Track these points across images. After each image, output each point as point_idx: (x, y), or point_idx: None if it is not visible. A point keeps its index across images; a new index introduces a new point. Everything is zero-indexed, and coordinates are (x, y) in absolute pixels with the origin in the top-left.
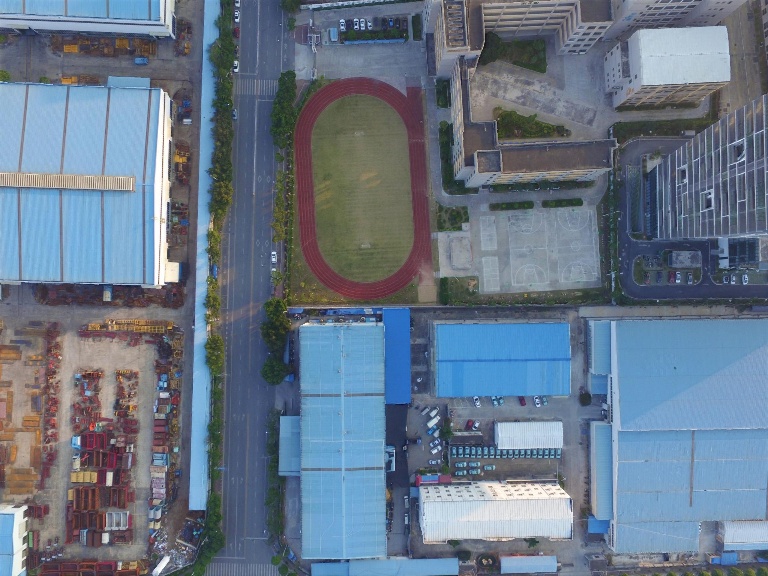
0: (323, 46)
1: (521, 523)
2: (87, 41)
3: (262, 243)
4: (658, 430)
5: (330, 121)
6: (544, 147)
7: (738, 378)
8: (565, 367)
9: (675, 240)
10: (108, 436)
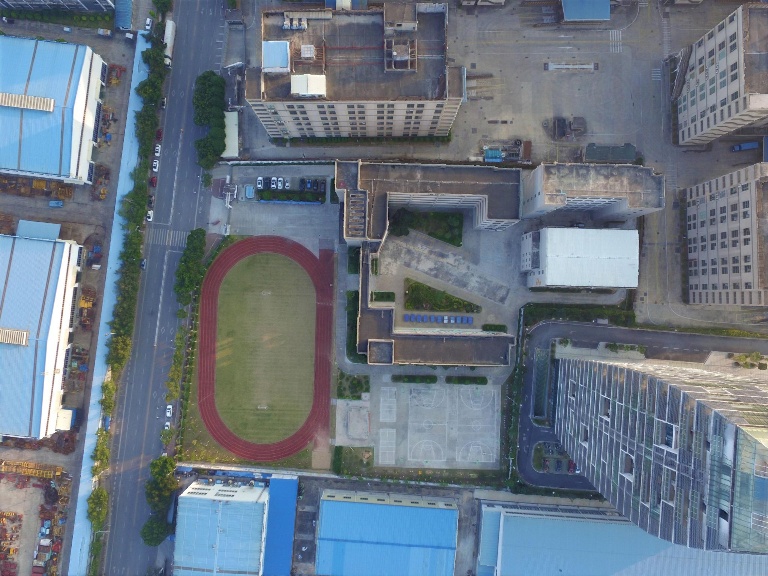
0: (239, 201)
1: None
2: (4, 180)
3: (159, 395)
4: None
5: (239, 277)
6: (441, 338)
7: None
8: (449, 556)
9: None
10: None
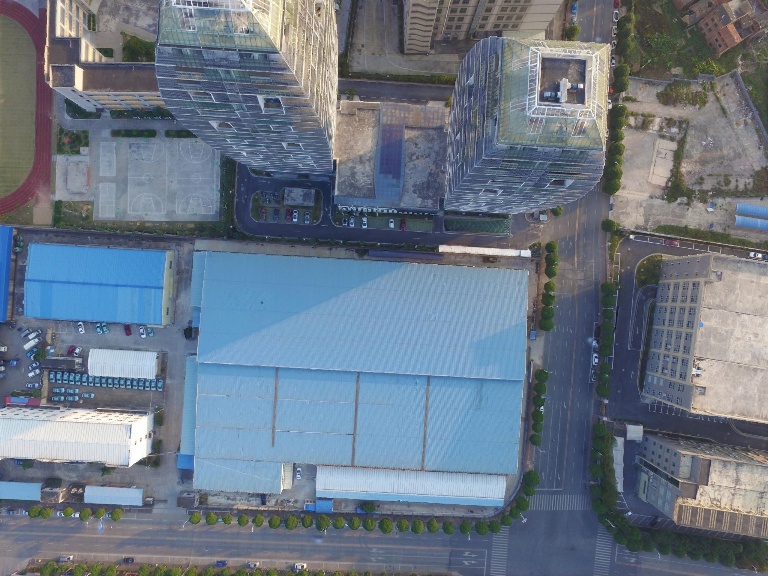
0: None
1: (76, 446)
2: None
3: None
4: (240, 365)
5: None
6: (130, 67)
7: (326, 317)
8: (157, 295)
9: (295, 178)
10: None
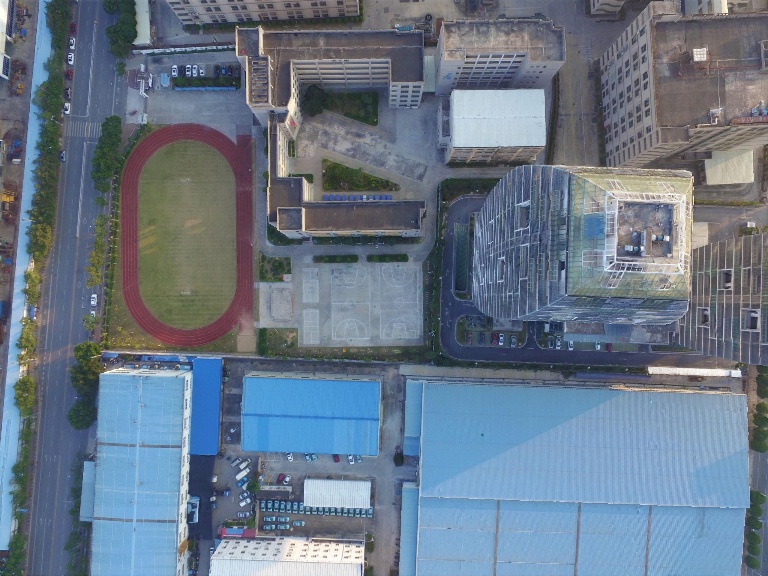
0: (155, 91)
1: None
2: None
3: (84, 285)
4: (462, 498)
5: (158, 166)
6: (351, 205)
7: (547, 449)
8: (373, 427)
9: None
10: None
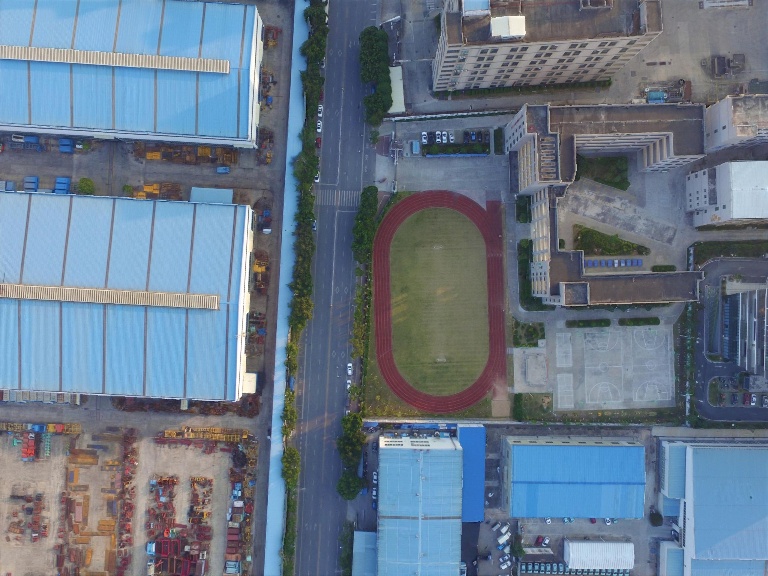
0: (404, 158)
1: None
2: (170, 149)
3: (338, 354)
4: (732, 559)
5: (409, 233)
6: (630, 277)
7: None
8: (639, 491)
9: None
10: (182, 542)
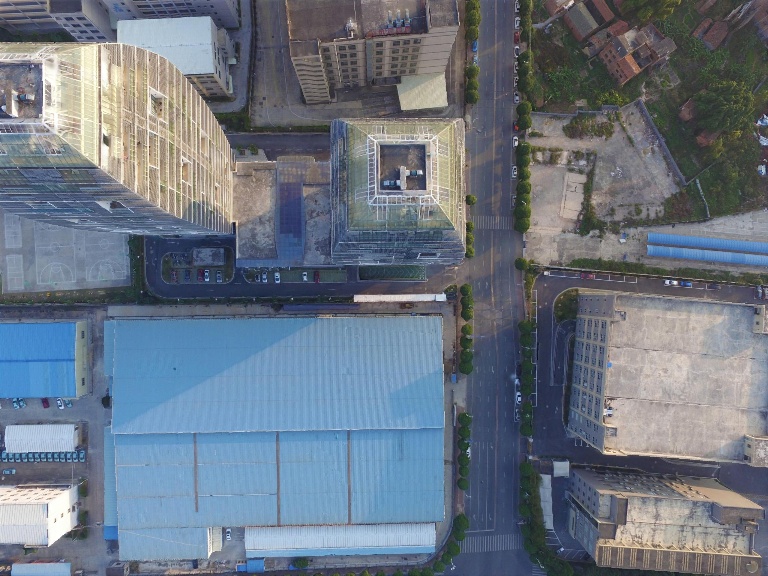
0: None
1: None
2: None
3: None
4: (156, 433)
5: None
6: None
7: (241, 379)
8: (69, 368)
9: (203, 237)
10: None
